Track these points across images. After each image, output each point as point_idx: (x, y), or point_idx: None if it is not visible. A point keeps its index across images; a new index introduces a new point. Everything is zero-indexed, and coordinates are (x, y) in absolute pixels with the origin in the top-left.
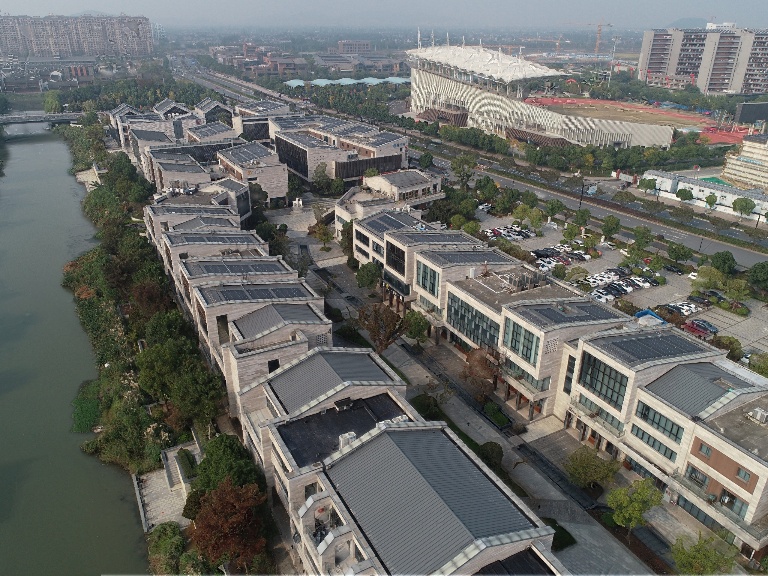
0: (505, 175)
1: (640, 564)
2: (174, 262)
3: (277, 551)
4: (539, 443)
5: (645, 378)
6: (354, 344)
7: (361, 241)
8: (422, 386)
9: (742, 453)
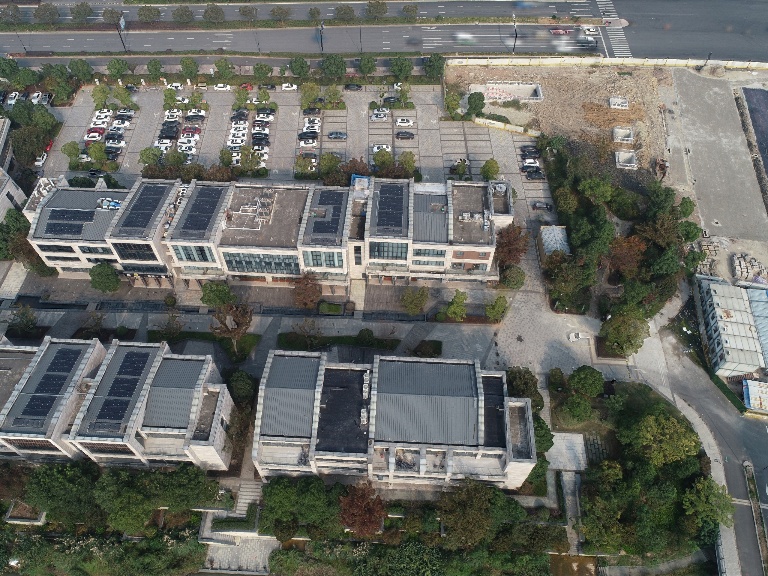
0: None
1: (467, 326)
2: None
3: None
4: (368, 305)
5: None
6: (178, 343)
7: (53, 251)
8: (268, 330)
9: (481, 247)
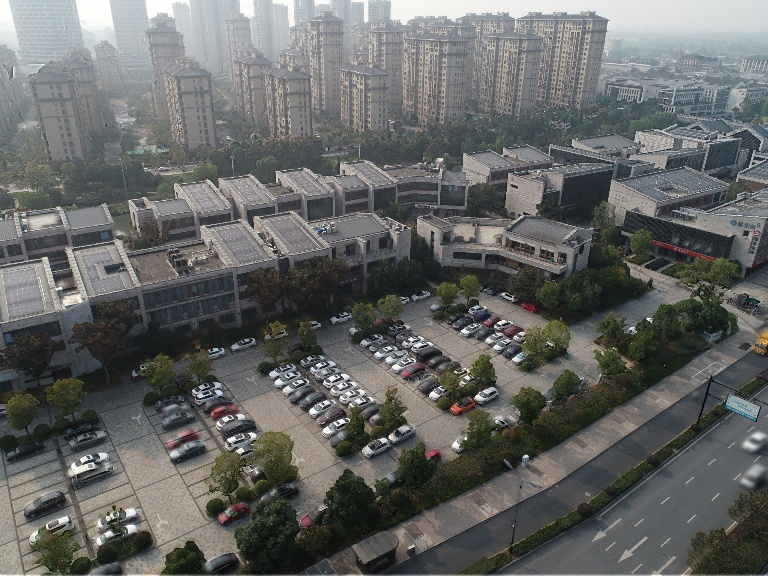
0: None
1: None
2: None
3: None
4: None
5: None
6: None
7: None
8: None
9: None
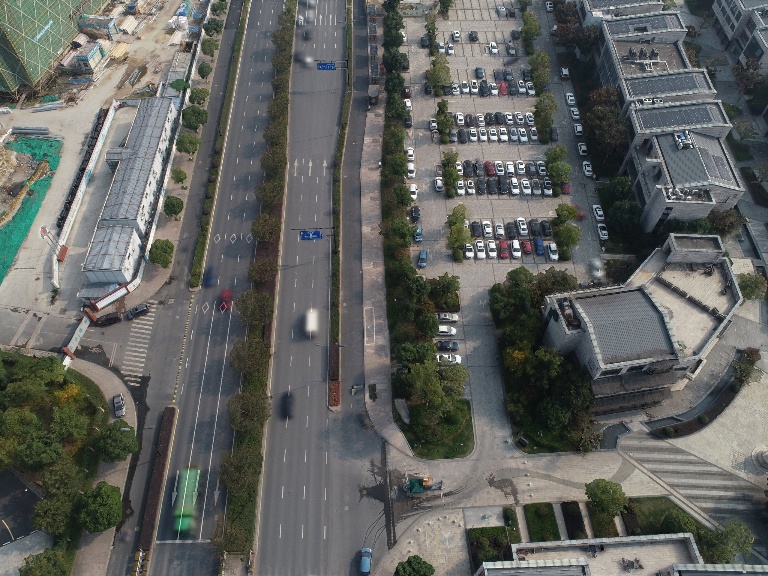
0: None
1: None
2: None
3: None
4: None
5: None
6: None
7: None
8: None
9: None
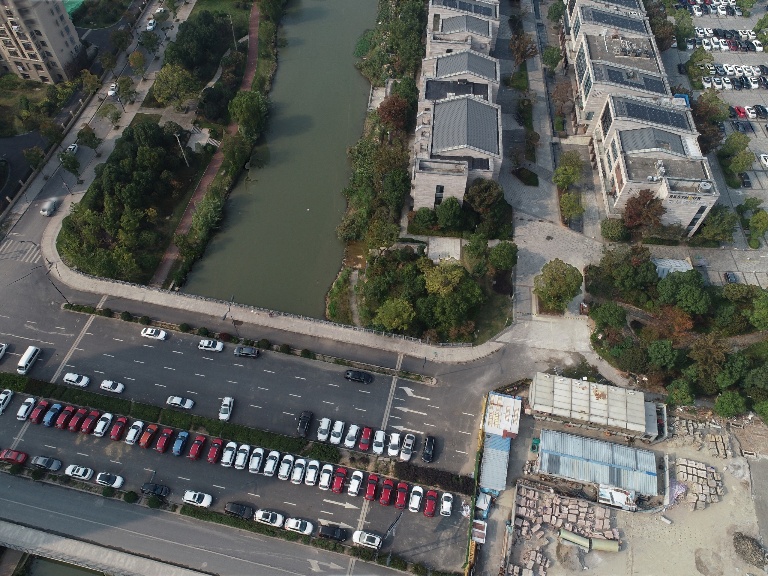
0: None
1: (557, 204)
2: None
3: (412, 136)
4: (567, 146)
5: (622, 126)
6: None
7: None
8: None
9: (624, 172)
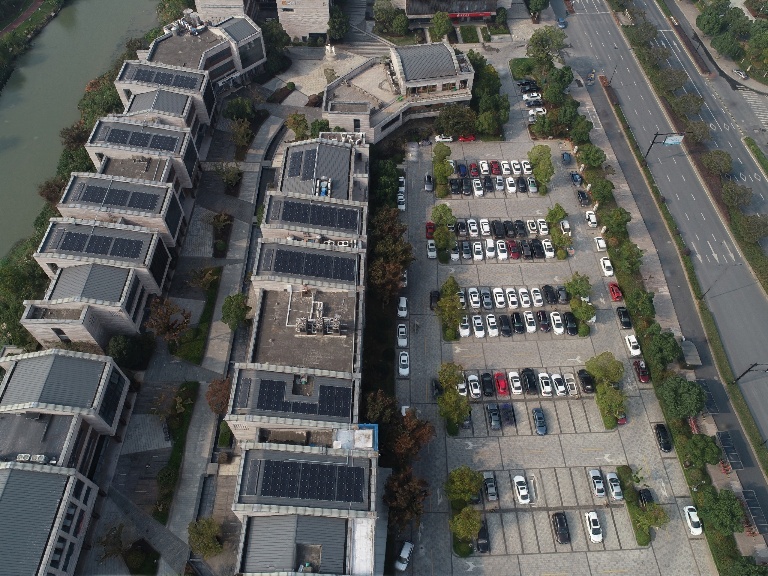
0: (636, 48)
1: None
2: (92, 158)
3: None
4: (226, 480)
5: (251, 513)
6: (204, 293)
7: None
8: (207, 371)
9: None
